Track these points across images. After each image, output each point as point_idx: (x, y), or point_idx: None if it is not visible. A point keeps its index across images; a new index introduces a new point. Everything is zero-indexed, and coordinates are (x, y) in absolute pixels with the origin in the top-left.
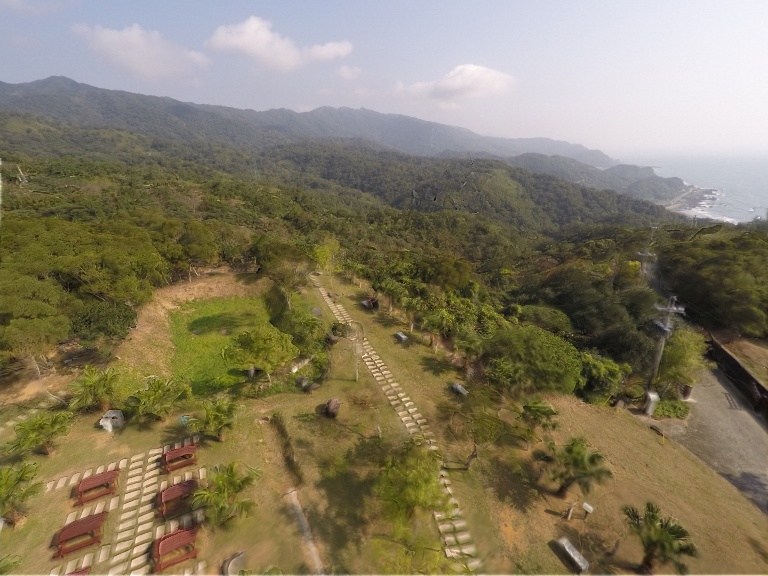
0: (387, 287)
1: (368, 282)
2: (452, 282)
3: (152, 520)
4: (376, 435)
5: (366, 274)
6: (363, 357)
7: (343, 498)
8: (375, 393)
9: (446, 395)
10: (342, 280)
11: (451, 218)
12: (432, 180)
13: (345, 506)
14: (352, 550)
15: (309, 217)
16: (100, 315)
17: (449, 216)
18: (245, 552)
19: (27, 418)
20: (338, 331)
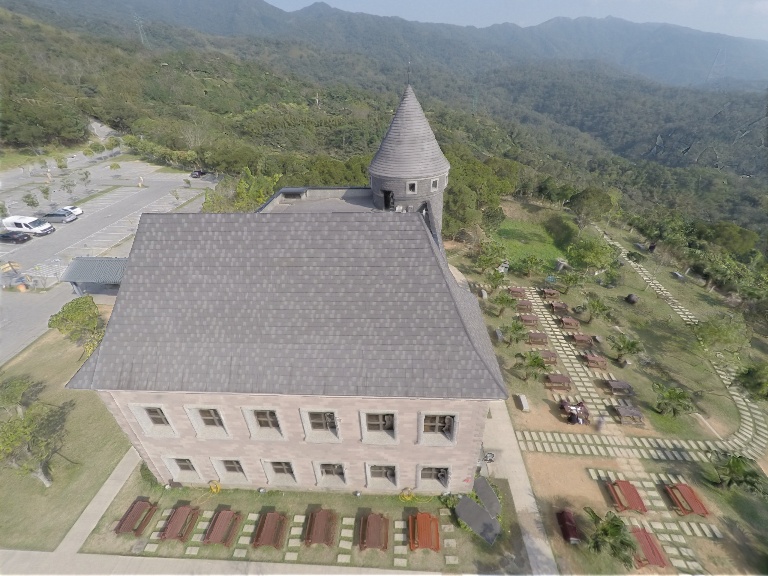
0: (668, 236)
1: (636, 230)
2: (731, 246)
3: (548, 312)
4: (665, 320)
5: (641, 223)
6: (645, 279)
7: (648, 338)
8: (659, 301)
9: (717, 318)
10: (612, 224)
11: (705, 178)
12: (691, 124)
13: (650, 341)
14: (658, 356)
15: (530, 157)
16: (496, 214)
17: (703, 175)
18: (601, 336)
19: (456, 257)
20: (634, 257)
